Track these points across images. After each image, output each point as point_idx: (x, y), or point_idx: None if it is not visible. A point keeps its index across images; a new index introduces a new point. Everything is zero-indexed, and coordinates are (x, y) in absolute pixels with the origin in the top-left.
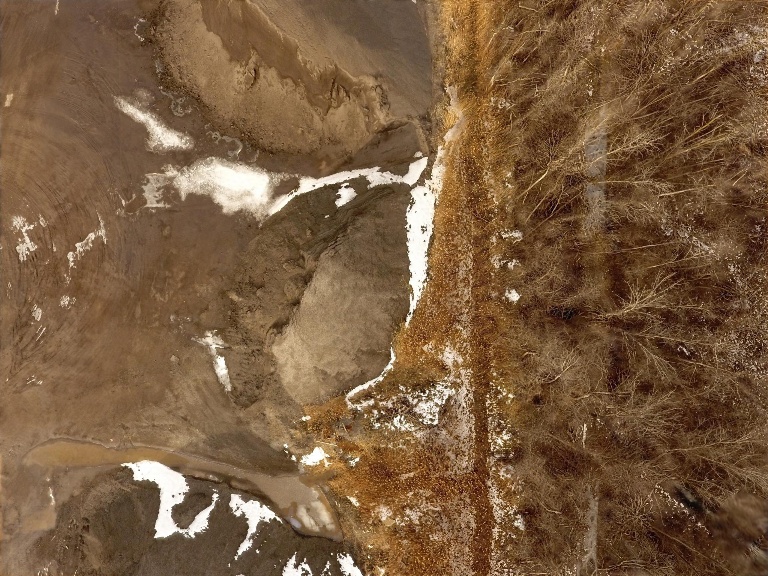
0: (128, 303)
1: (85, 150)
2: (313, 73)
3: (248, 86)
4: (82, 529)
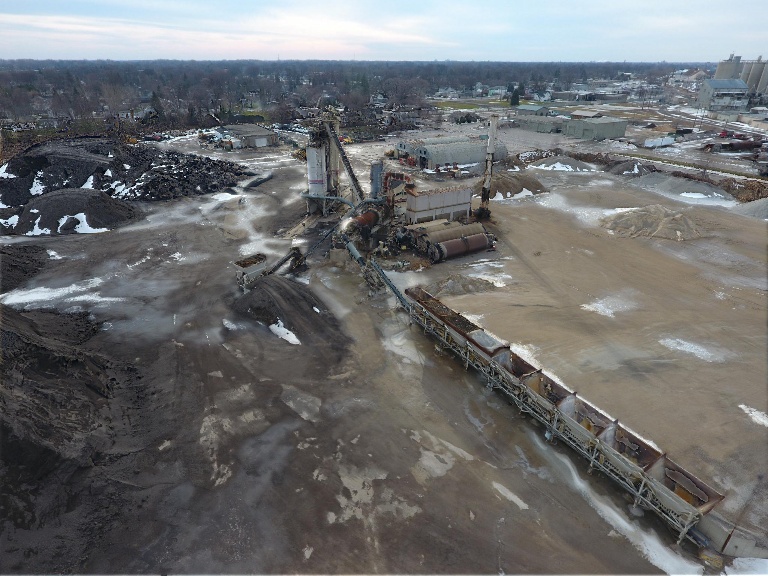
0: (111, 255)
1: (144, 282)
2: None
3: None
4: (132, 217)
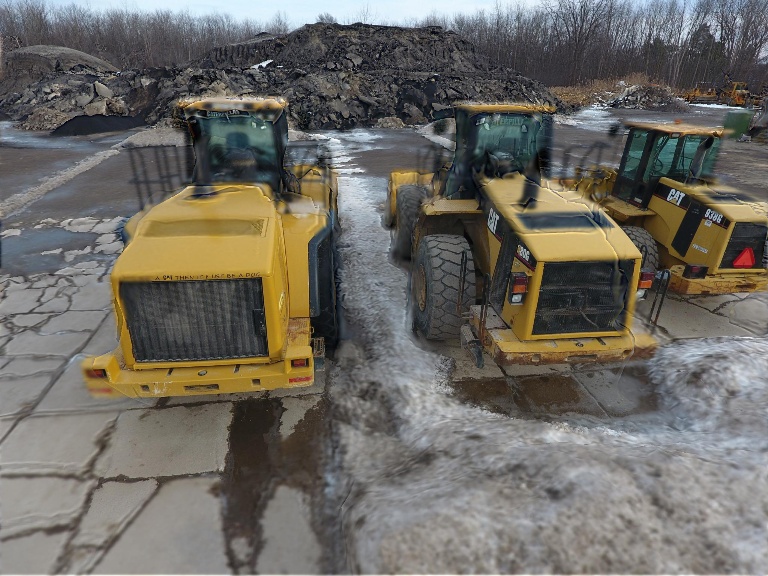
0: None
1: None
2: None
3: None
4: None
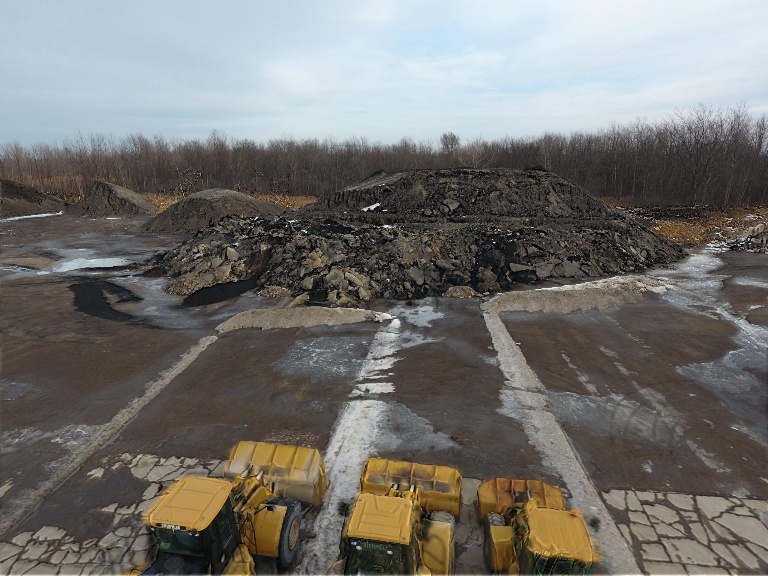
0: None
1: None
2: (24, 188)
3: (0, 203)
4: None
